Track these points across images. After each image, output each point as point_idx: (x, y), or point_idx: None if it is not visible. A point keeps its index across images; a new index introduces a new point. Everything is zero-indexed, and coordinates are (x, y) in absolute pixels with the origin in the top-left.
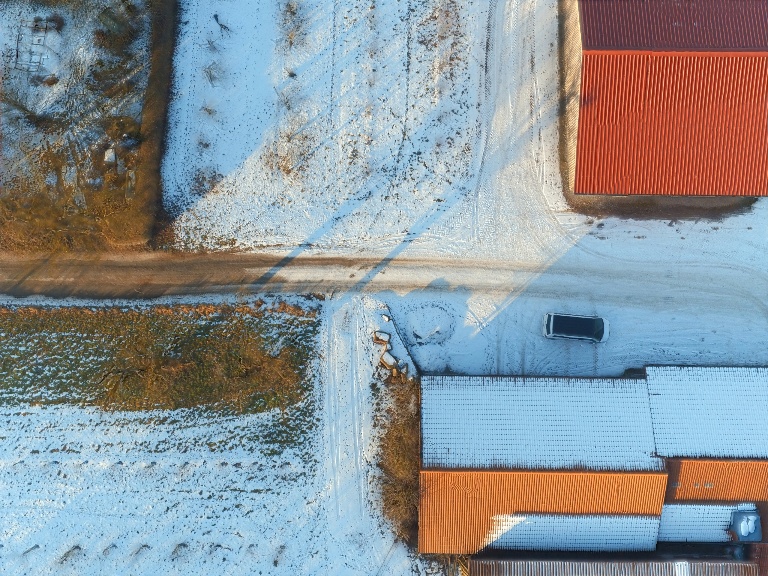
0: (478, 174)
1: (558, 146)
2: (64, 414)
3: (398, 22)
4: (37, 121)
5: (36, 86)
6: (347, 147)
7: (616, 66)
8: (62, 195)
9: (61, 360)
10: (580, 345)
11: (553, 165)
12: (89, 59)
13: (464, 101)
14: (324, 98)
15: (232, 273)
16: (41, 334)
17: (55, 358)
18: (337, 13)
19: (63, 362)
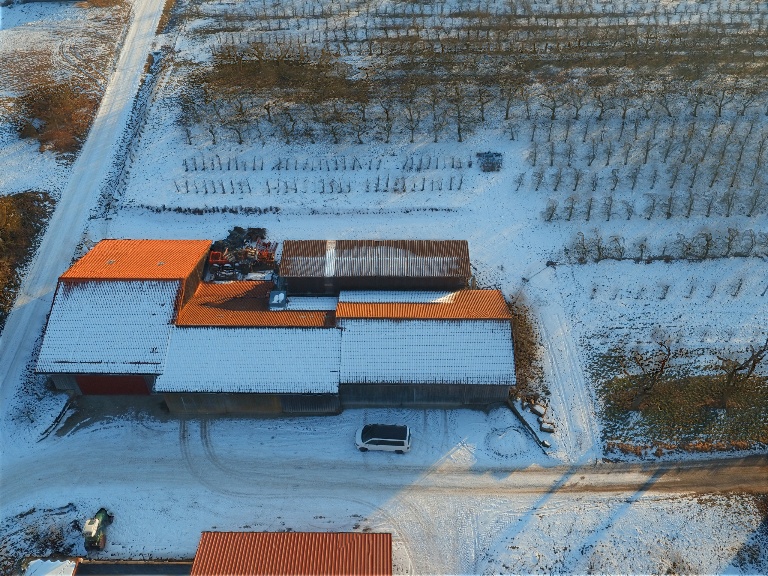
0: None
1: None
2: None
3: None
4: None
5: None
6: None
7: None
8: None
9: None
10: None
11: None
12: None
13: None
14: None
15: (691, 476)
16: None
17: None
18: None
19: None
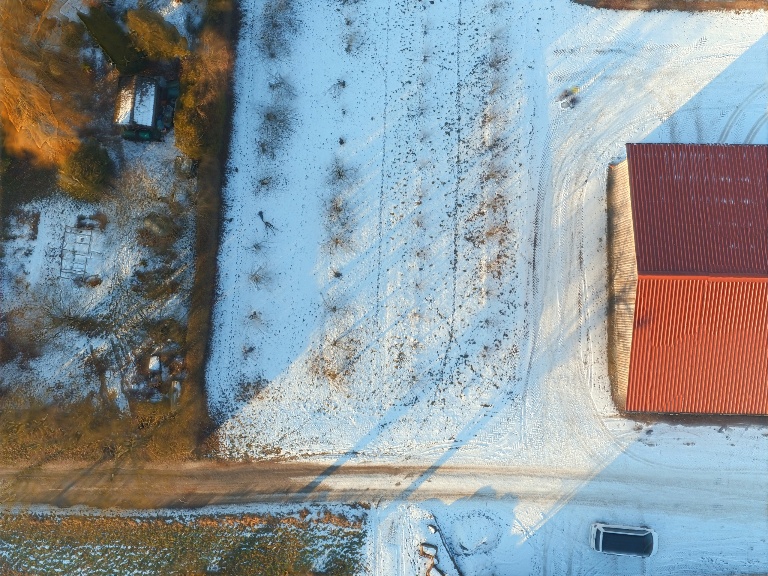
0: (525, 377)
1: (607, 347)
2: None
3: (445, 218)
4: (80, 324)
5: (79, 287)
6: (393, 350)
7: (672, 290)
8: (106, 401)
9: (105, 574)
10: None
11: (601, 367)
12: (133, 259)
13: (512, 301)
14: (370, 299)
15: (277, 482)
16: (85, 547)
17: (99, 572)
18: (383, 209)
19: (107, 575)
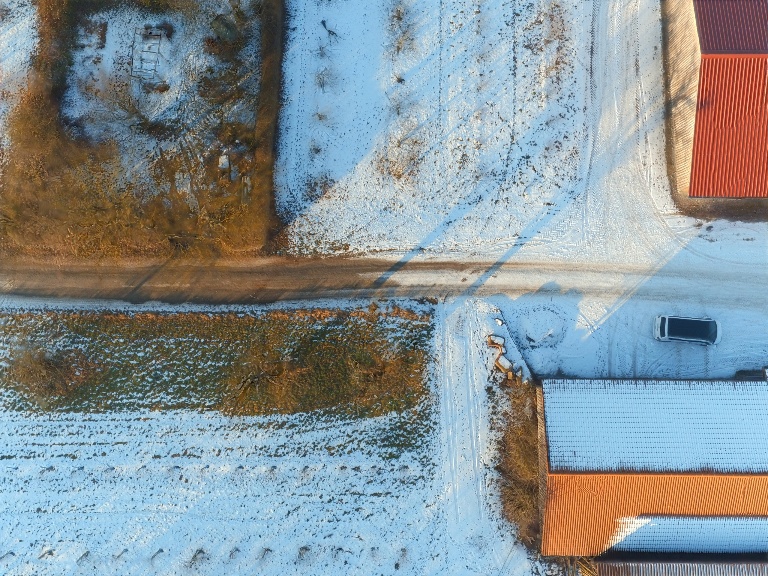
0: (586, 177)
1: (665, 149)
2: (184, 419)
3: (503, 26)
4: (150, 128)
5: (147, 93)
6: (456, 152)
7: (734, 70)
8: (176, 201)
9: (179, 365)
10: (691, 347)
11: (660, 168)
12: (199, 66)
13: (571, 105)
14: (432, 103)
15: (346, 278)
16: (159, 340)
17: (173, 364)
18: (443, 18)
19: (182, 367)
